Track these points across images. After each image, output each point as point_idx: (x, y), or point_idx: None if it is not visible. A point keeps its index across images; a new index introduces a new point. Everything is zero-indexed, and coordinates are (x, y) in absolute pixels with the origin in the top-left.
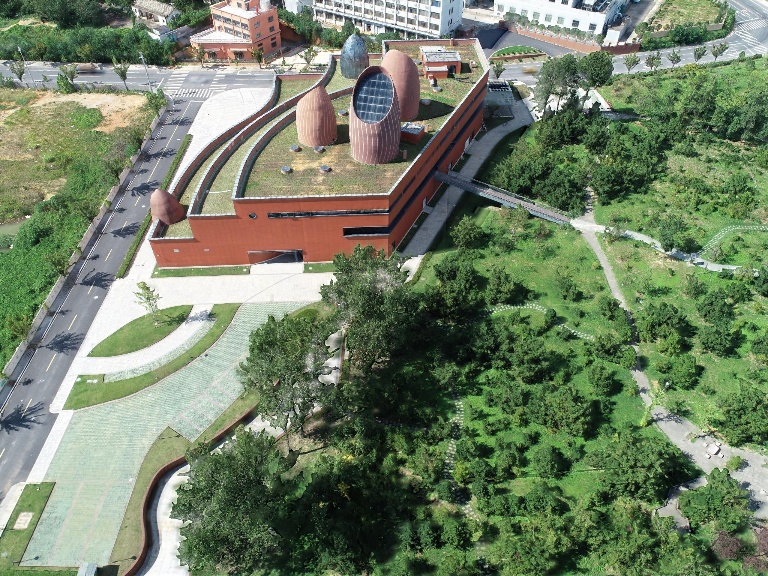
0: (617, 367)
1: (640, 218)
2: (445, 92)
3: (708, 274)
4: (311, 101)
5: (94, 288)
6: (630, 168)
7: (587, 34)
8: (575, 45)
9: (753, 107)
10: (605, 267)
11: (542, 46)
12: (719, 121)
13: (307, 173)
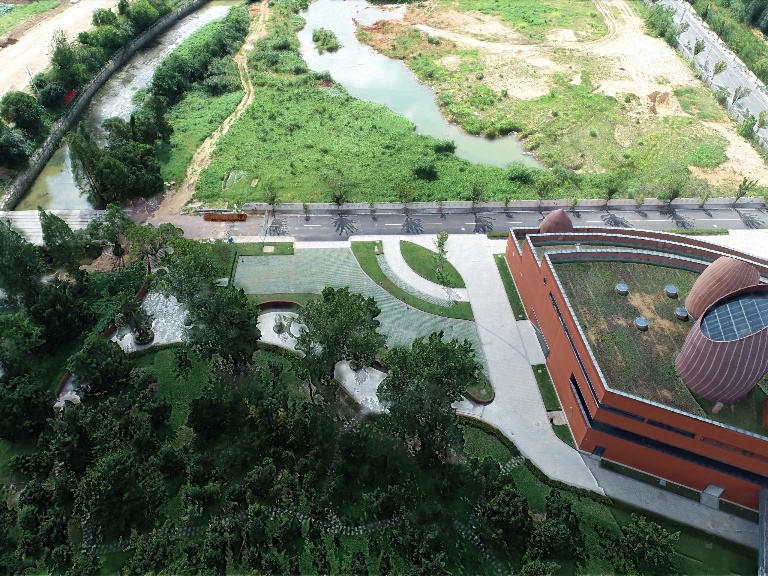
0: None
1: None
2: None
3: None
4: (720, 266)
5: (473, 225)
6: None
7: None
8: None
9: None
10: None
11: None
12: None
13: (626, 309)
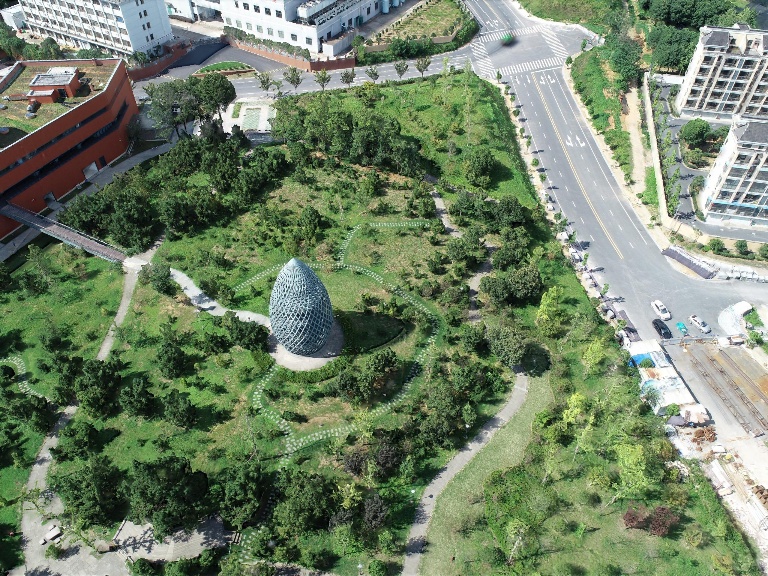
0: (34, 433)
1: (197, 255)
2: (37, 119)
3: (206, 321)
4: None
5: None
6: (199, 201)
7: (294, 49)
8: (288, 60)
9: (359, 132)
10: (120, 313)
11: (255, 61)
12: (338, 146)
13: None
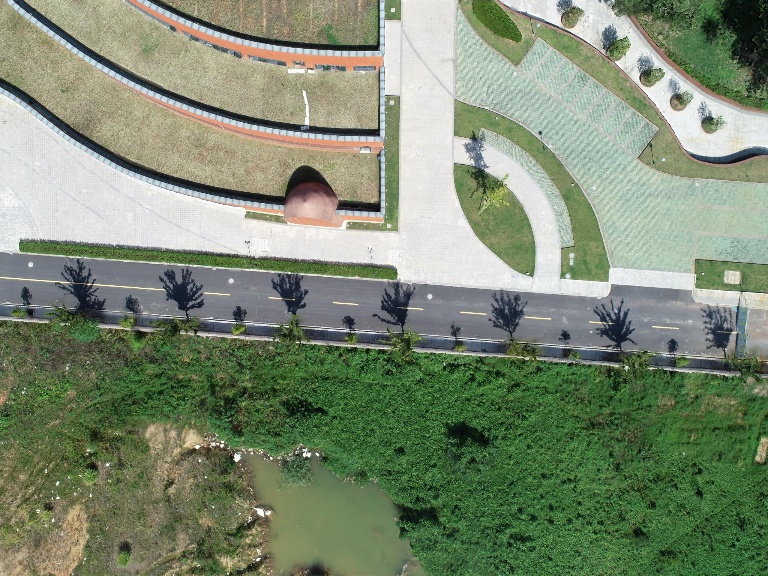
0: None
1: None
2: None
3: None
4: None
5: (412, 304)
6: None
7: None
8: None
9: None
10: None
11: None
12: None
13: None
